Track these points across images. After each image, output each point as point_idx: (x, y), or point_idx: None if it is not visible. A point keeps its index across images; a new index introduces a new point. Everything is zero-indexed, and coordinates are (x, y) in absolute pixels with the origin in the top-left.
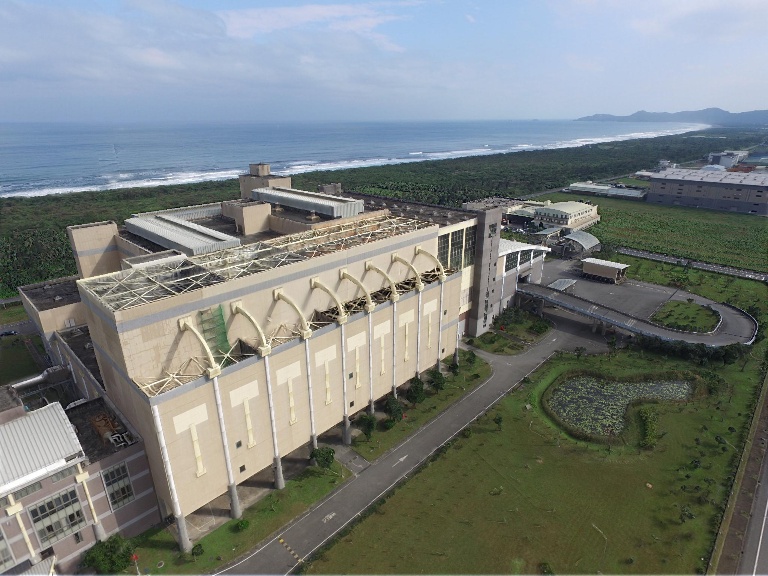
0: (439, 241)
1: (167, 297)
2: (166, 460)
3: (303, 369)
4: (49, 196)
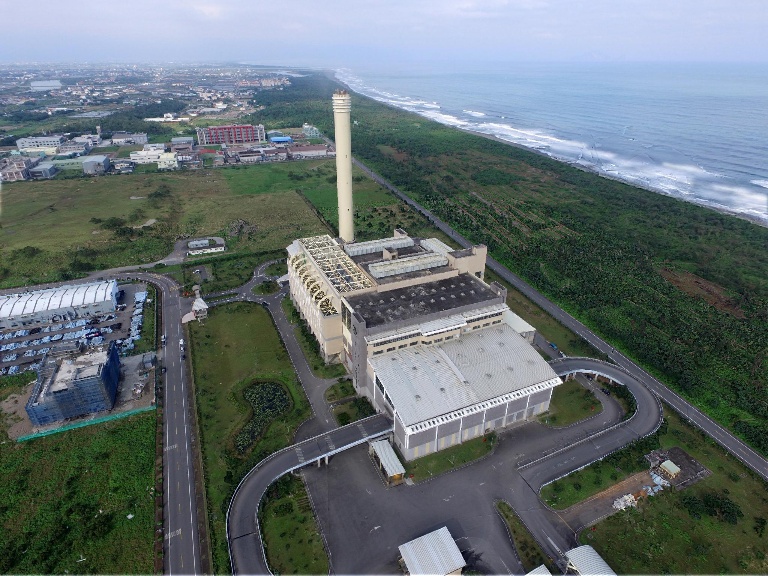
0: None
1: (302, 243)
2: None
3: None
4: None
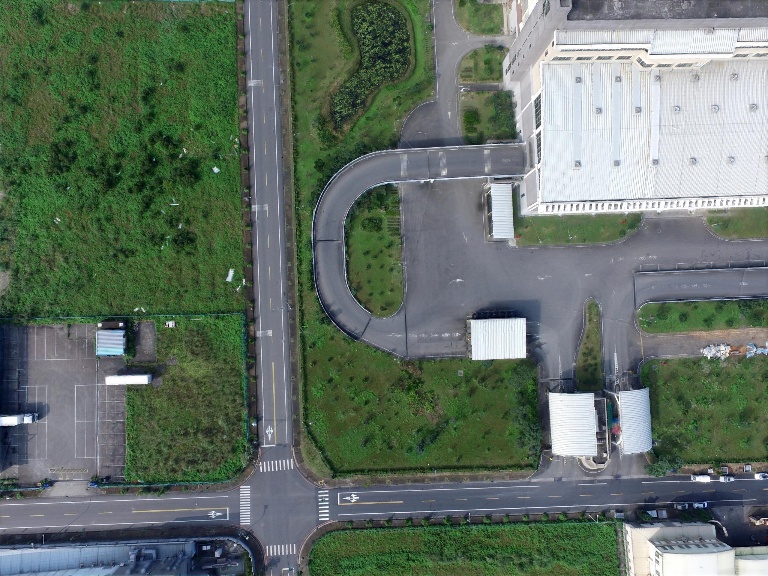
0: None
1: None
2: None
3: None
4: None
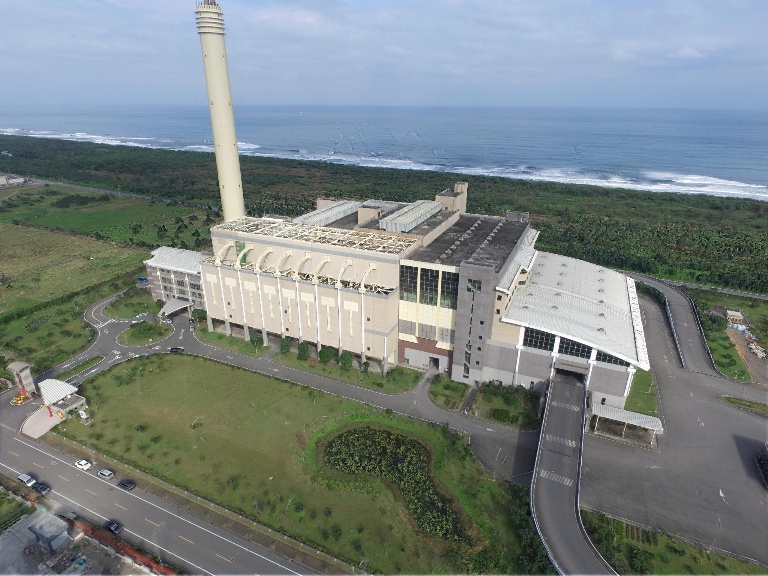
0: (405, 269)
1: None
2: (203, 288)
3: (257, 289)
4: (523, 181)
